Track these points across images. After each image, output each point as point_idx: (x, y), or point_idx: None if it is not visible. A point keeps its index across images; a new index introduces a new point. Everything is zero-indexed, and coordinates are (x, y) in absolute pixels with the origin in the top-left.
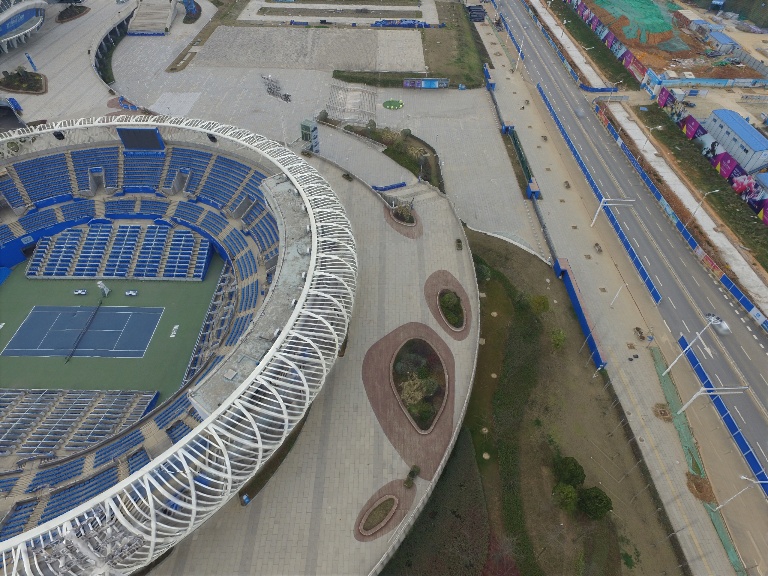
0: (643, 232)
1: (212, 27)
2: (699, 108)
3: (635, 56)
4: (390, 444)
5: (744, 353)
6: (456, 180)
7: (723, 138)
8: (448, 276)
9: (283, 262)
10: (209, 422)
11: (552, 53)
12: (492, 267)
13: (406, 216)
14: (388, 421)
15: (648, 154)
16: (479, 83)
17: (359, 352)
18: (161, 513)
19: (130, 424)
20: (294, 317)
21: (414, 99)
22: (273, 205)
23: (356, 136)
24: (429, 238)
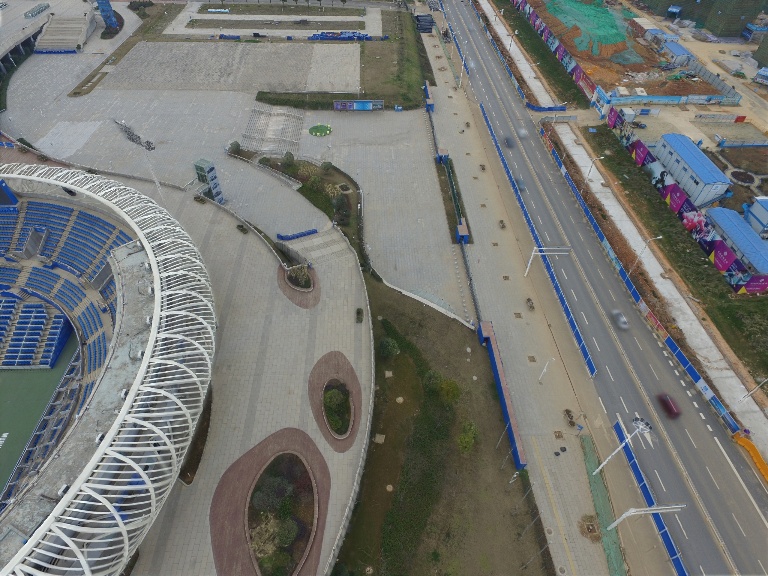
0: (582, 281)
1: (132, 43)
2: (650, 129)
3: None
4: None
5: (689, 439)
6: (379, 222)
7: (673, 166)
8: (340, 360)
9: (105, 372)
10: None
11: (500, 67)
12: (404, 336)
13: (301, 280)
14: None
15: (594, 184)
16: (418, 103)
17: (213, 476)
18: None
19: None
20: (93, 462)
21: (344, 123)
22: (118, 284)
23: (271, 170)
24: (325, 307)
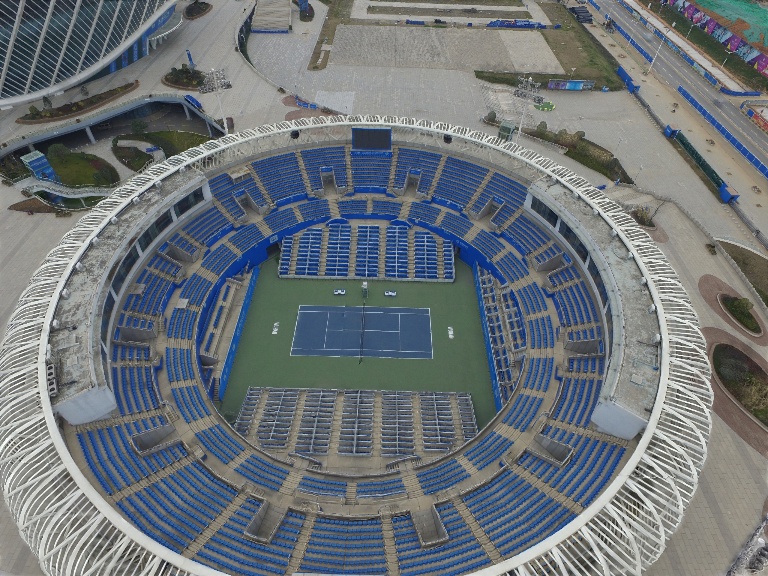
0: None
1: (332, 25)
2: None
3: None
4: (754, 450)
5: None
6: (644, 183)
7: None
8: (717, 281)
9: (609, 266)
10: (655, 427)
11: (675, 56)
12: None
13: (647, 220)
14: (739, 426)
15: None
16: (620, 85)
17: None
18: (663, 518)
19: (467, 426)
20: (664, 322)
21: (562, 101)
22: (555, 208)
23: None
24: (677, 242)
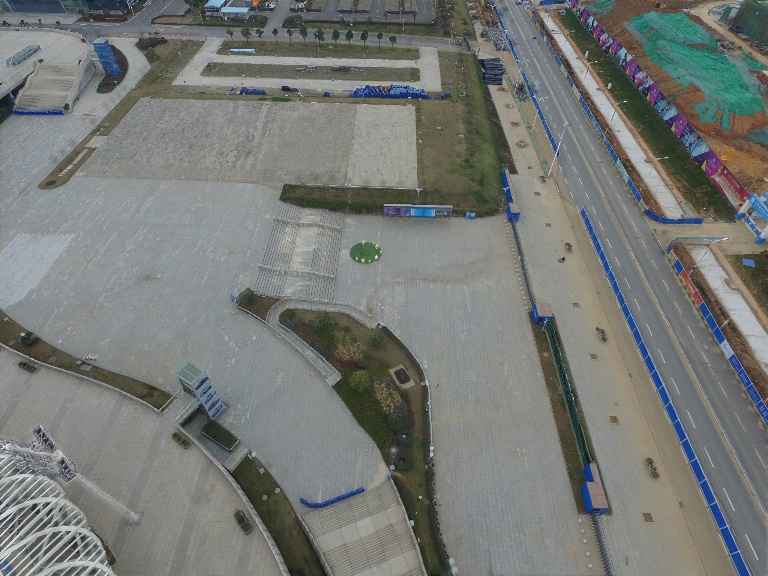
0: None
1: (133, 99)
2: None
3: (724, 163)
4: None
5: None
6: (456, 452)
7: None
8: None
9: None
10: None
11: (597, 142)
12: None
13: None
14: None
15: None
16: (496, 206)
17: None
18: None
19: None
20: None
21: (398, 239)
22: None
23: (296, 338)
24: None
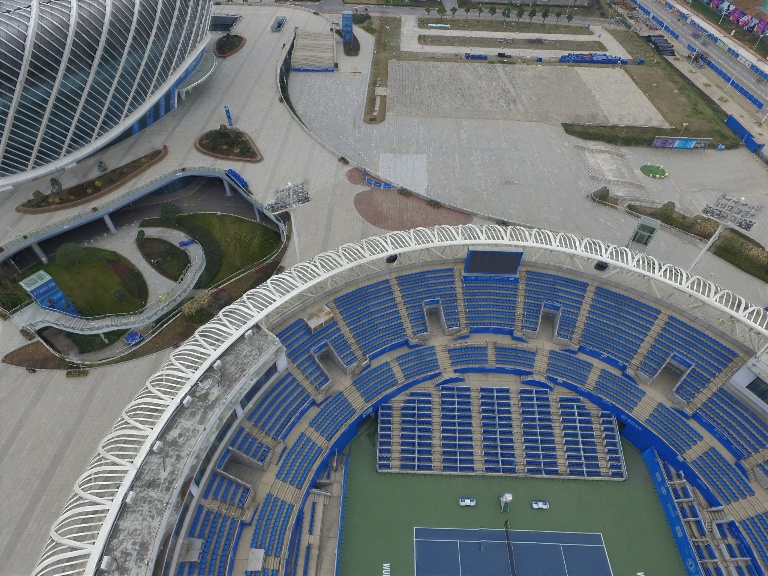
0: None
1: (382, 61)
2: None
3: None
4: None
5: None
6: None
7: None
8: None
9: None
10: None
11: None
12: None
13: None
14: None
15: None
16: (736, 141)
17: None
18: None
19: None
20: None
21: (673, 163)
22: None
23: None
24: None
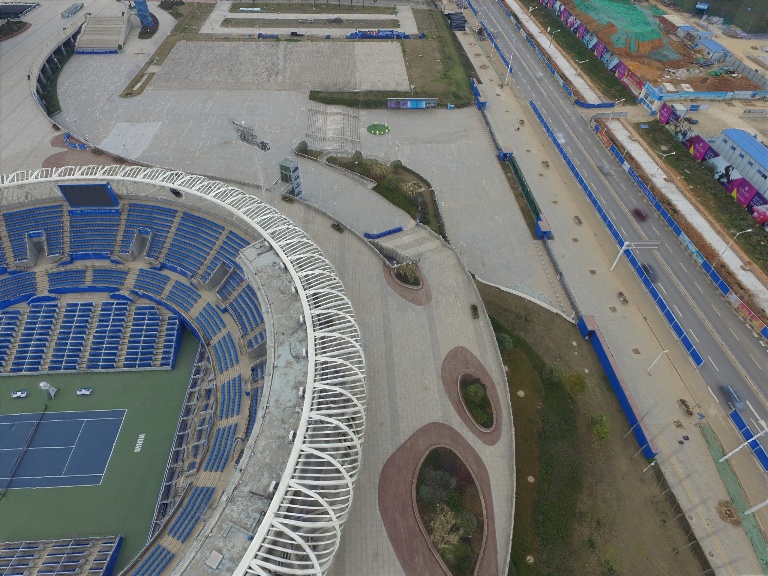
0: (667, 275)
1: (171, 42)
2: (702, 125)
3: (629, 68)
4: None
5: None
6: (456, 219)
7: (736, 161)
8: (467, 355)
9: (273, 370)
10: None
11: (540, 64)
12: (511, 331)
13: (410, 277)
14: (418, 574)
15: (657, 179)
16: (468, 101)
17: (372, 471)
18: None
19: None
20: (294, 459)
21: (400, 122)
22: (255, 284)
23: (341, 170)
24: (439, 304)
